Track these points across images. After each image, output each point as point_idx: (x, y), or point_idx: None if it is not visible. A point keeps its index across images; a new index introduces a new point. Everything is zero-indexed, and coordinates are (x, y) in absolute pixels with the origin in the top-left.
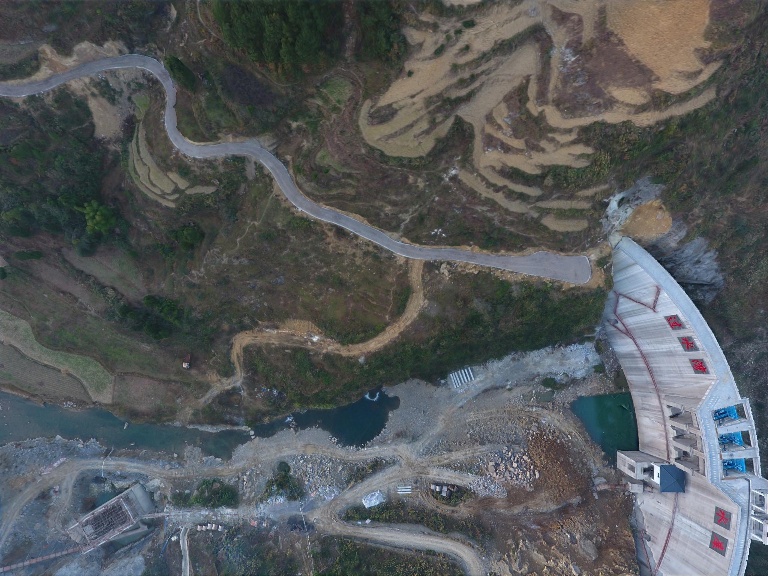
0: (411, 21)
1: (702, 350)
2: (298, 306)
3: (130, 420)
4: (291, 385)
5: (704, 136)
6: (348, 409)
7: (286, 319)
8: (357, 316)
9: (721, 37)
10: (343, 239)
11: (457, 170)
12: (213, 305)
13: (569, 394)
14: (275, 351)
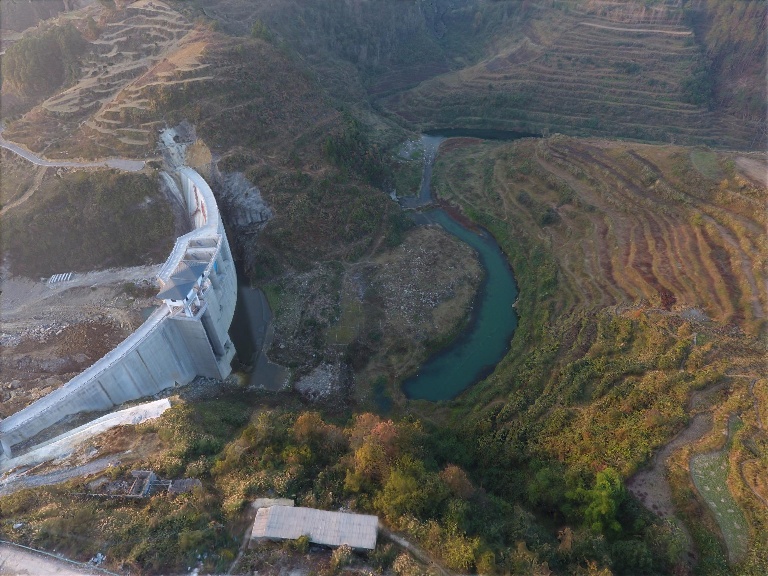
0: (85, 63)
1: (206, 214)
2: None
3: None
4: None
5: (214, 100)
6: None
7: None
8: None
9: (209, 54)
10: (10, 158)
11: (87, 121)
12: None
13: (146, 302)
14: None
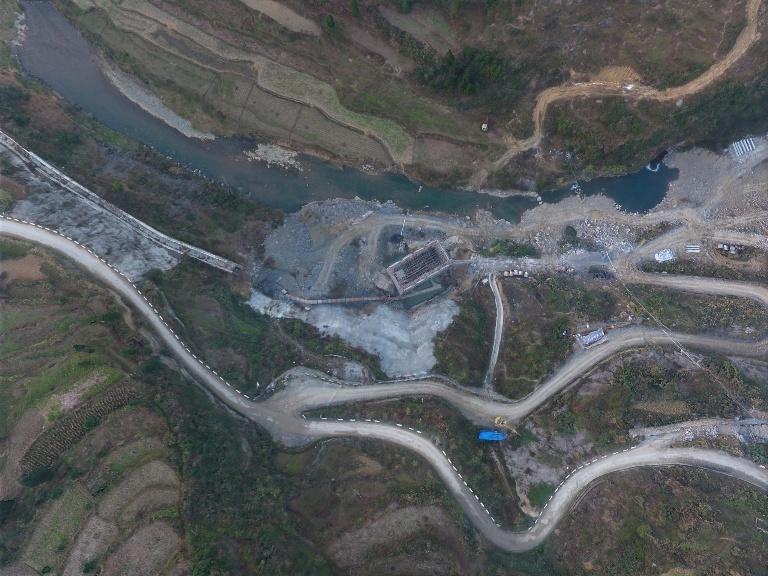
0: None
1: None
2: (620, 51)
3: (426, 183)
4: (595, 140)
5: None
6: (629, 179)
7: (603, 67)
8: (684, 55)
9: None
10: None
11: None
12: (534, 53)
13: None
14: (584, 103)
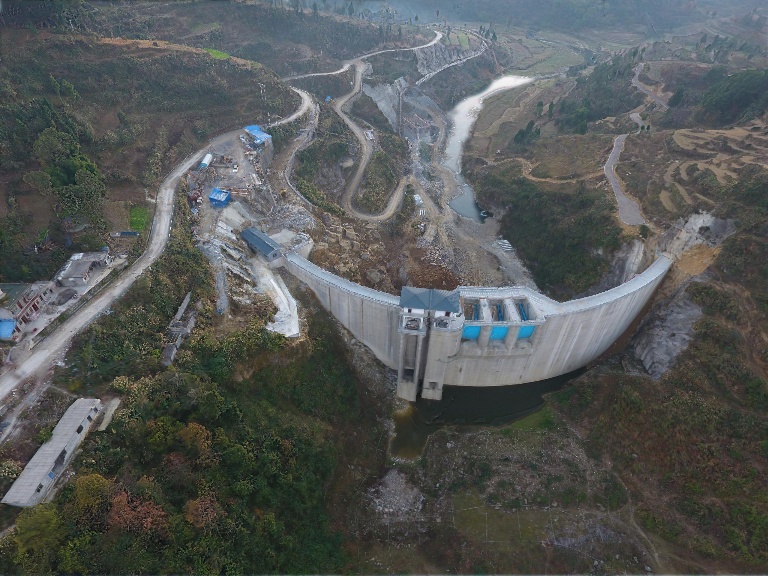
0: None
1: None
2: None
3: None
4: None
5: None
6: (474, 205)
7: None
8: (553, 169)
9: None
10: None
11: (679, 162)
12: None
13: None
14: None
